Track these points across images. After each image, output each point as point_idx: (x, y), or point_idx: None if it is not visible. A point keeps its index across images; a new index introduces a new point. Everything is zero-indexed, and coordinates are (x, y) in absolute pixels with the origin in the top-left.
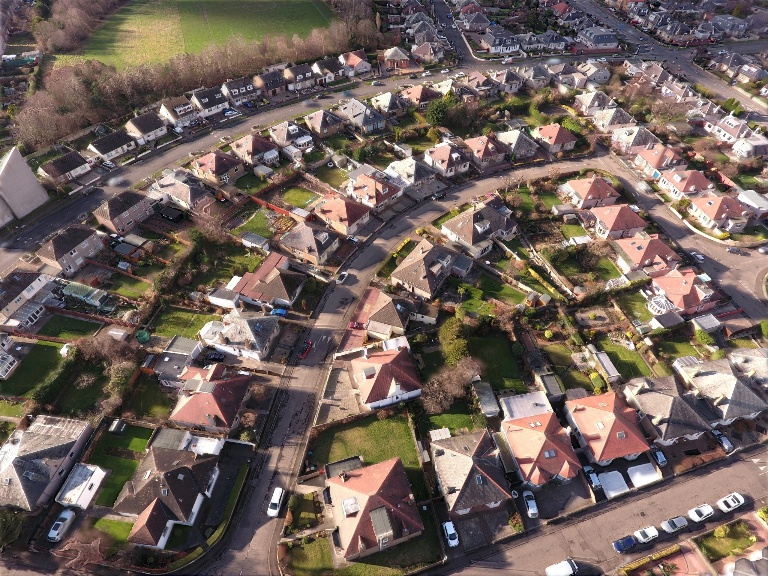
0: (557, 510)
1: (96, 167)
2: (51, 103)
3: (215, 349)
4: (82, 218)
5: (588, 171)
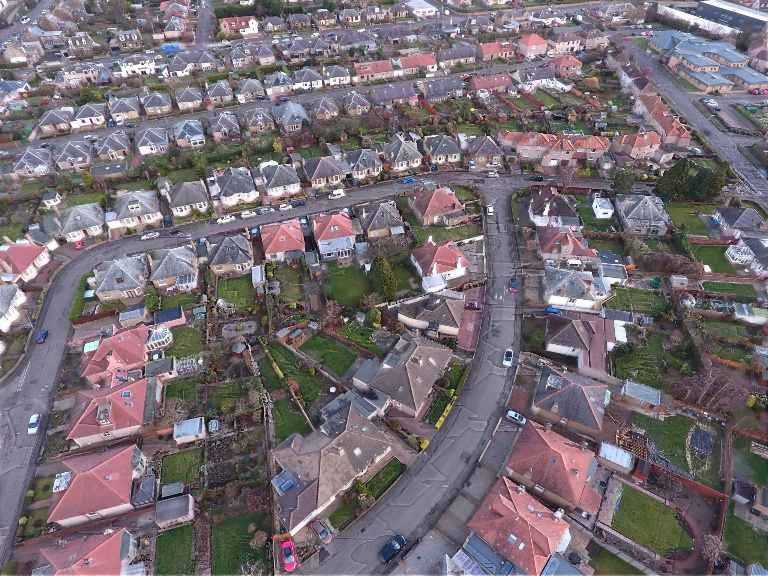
0: None
1: None
2: None
3: None
4: None
5: None
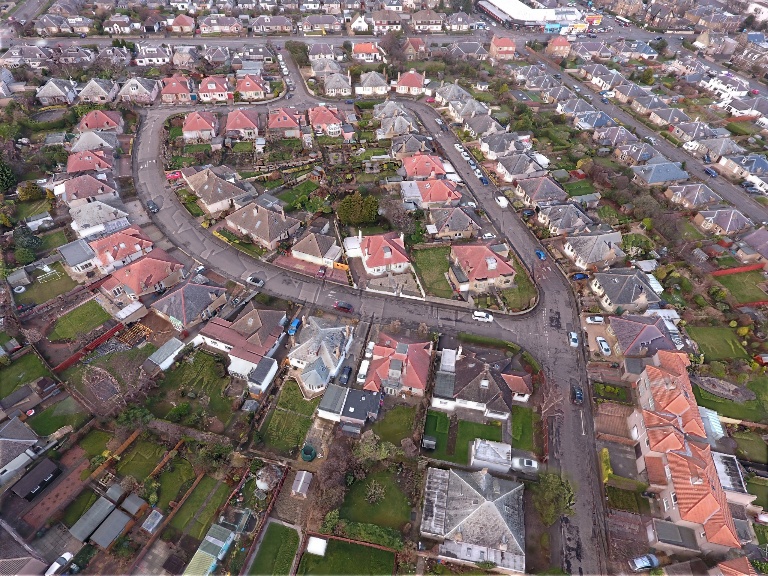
0: (470, 198)
1: None
2: None
3: (334, 378)
4: None
5: (169, 121)
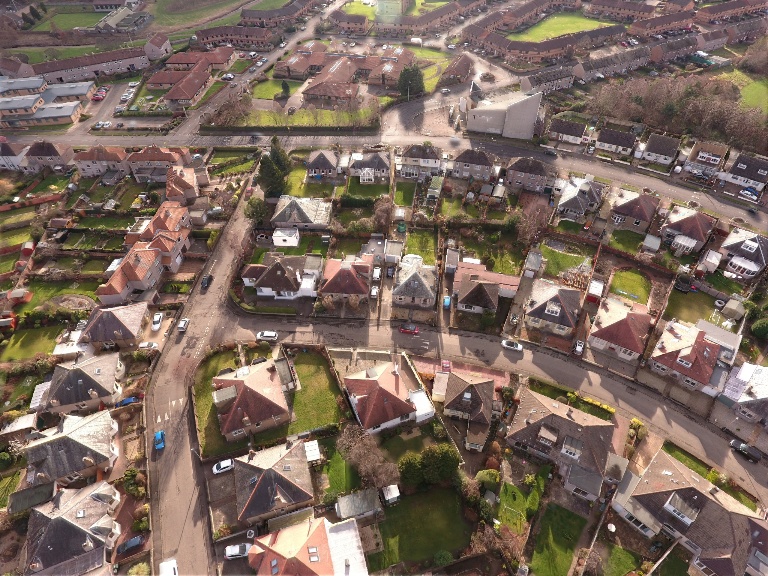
0: None
1: (584, 146)
2: (639, 91)
3: None
4: None
5: None
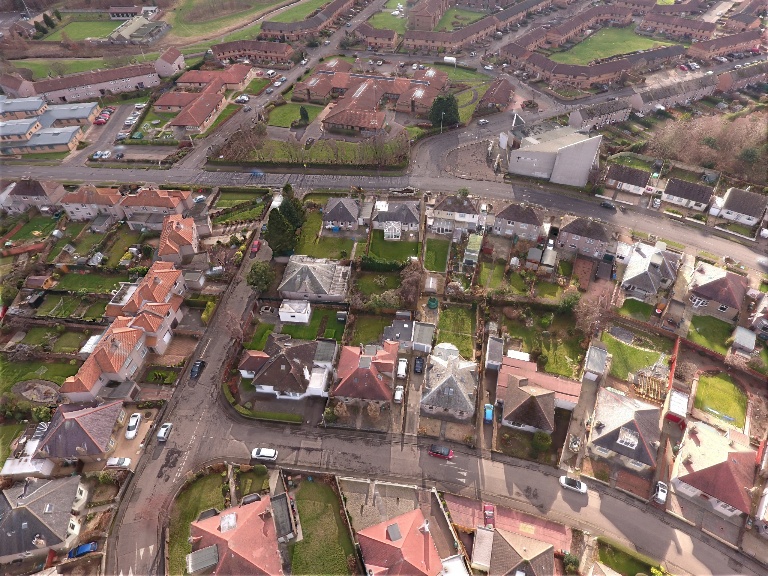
0: None
1: (648, 197)
2: (711, 131)
3: None
4: (567, 214)
5: None
